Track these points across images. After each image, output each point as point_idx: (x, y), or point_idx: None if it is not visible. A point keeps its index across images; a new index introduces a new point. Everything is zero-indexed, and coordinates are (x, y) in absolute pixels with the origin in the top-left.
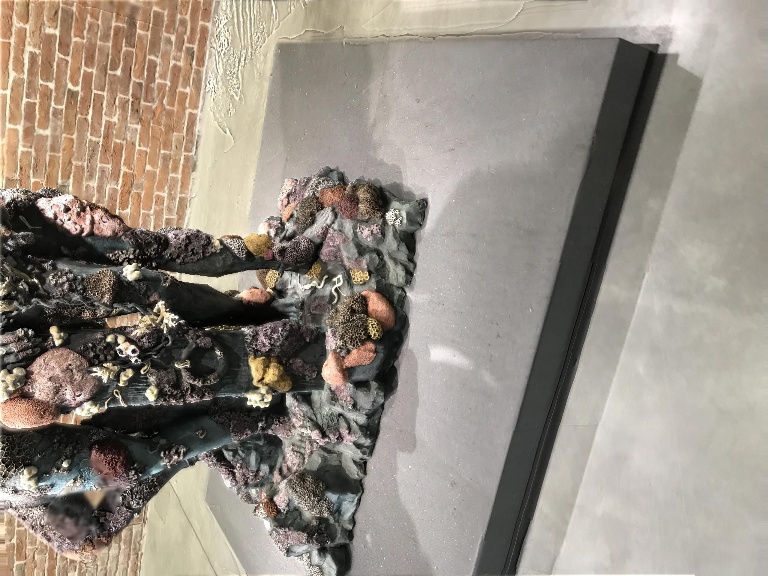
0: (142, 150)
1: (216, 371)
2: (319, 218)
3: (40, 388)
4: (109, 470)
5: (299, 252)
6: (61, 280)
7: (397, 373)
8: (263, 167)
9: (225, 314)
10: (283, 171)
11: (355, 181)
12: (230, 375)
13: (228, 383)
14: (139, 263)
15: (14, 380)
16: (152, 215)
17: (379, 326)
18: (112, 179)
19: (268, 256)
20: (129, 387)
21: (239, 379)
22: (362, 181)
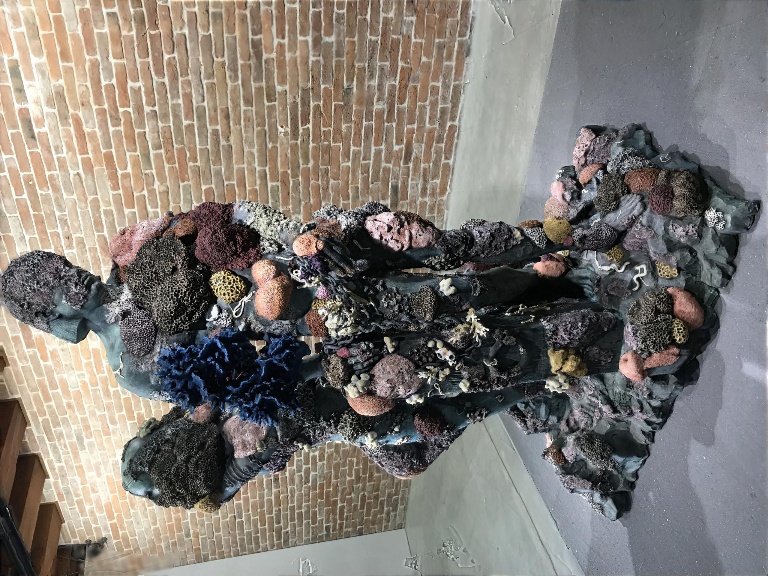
0: (418, 42)
1: (519, 364)
2: (624, 204)
3: (380, 388)
4: (428, 433)
5: (601, 241)
6: (392, 303)
7: (699, 367)
8: (552, 92)
9: (523, 294)
10: (576, 104)
11: (668, 156)
12: (531, 365)
13: (529, 372)
14: (449, 264)
15: (362, 386)
16: (427, 106)
17: (686, 330)
18: (391, 76)
19: (568, 243)
20: (446, 381)
21: (539, 368)
22: (676, 156)
